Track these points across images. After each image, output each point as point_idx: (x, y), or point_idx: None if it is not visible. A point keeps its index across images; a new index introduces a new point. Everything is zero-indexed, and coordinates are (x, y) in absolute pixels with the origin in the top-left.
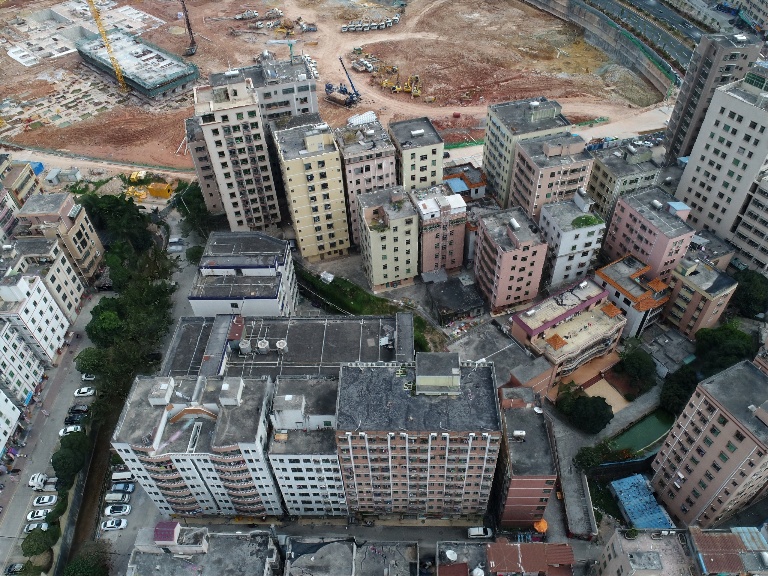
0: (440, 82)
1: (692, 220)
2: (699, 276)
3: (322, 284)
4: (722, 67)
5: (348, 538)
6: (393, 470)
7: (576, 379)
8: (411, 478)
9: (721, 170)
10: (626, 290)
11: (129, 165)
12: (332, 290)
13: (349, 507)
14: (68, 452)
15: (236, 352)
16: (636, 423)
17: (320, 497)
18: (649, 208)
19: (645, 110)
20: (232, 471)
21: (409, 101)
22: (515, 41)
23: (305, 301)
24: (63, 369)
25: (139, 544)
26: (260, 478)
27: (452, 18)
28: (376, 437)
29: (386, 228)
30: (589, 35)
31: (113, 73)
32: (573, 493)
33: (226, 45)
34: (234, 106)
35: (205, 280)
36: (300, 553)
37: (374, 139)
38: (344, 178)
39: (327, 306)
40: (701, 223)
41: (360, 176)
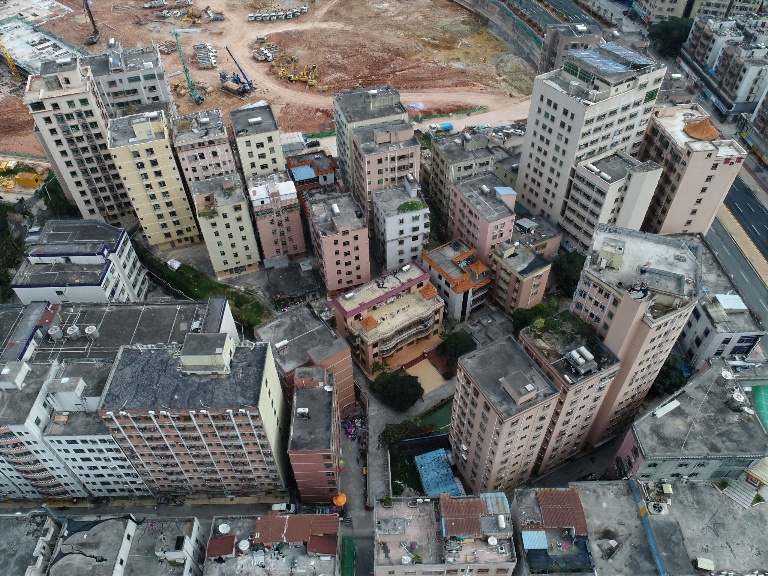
0: (337, 72)
1: (532, 205)
2: (517, 258)
3: (169, 271)
4: (565, 56)
5: (124, 515)
6: (173, 449)
7: (400, 359)
8: (194, 456)
9: (547, 156)
10: (446, 272)
11: (2, 155)
12: (178, 277)
13: (149, 487)
14: None
15: (47, 338)
16: (449, 400)
17: (116, 478)
18: (478, 193)
19: (525, 99)
20: (14, 454)
21: (303, 90)
22: (419, 31)
23: (157, 289)
24: None
25: None
26: (47, 460)
27: (361, 8)
28: (139, 416)
29: (214, 215)
30: (492, 25)
31: (6, 62)
32: (378, 468)
33: (130, 34)
34: (65, 94)
35: (33, 268)
36: (74, 531)
37: (208, 127)
38: (179, 166)
39: (176, 293)
40: (539, 208)
41: (195, 164)
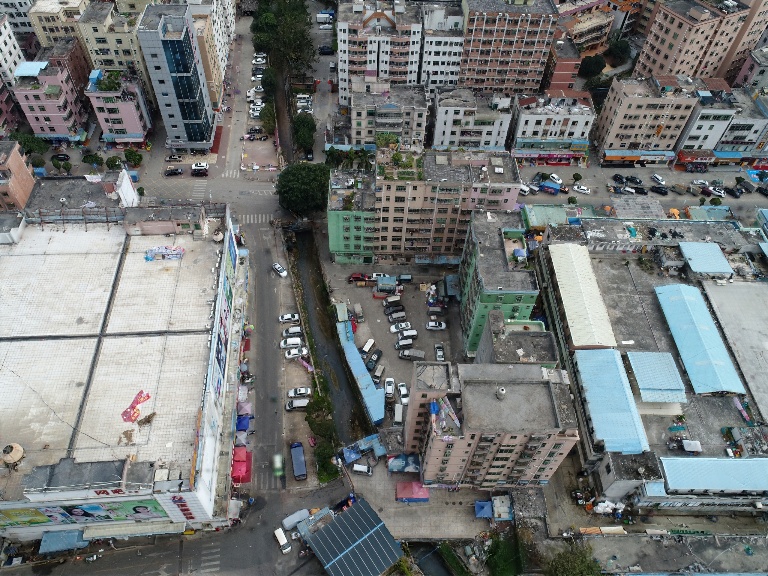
0: None
1: None
2: None
3: None
4: None
5: (468, 87)
6: (492, 54)
7: None
8: (500, 63)
9: None
10: None
11: None
12: None
13: None
14: (272, 74)
15: None
16: None
17: (442, 85)
18: None
19: None
20: (400, 52)
21: None
22: None
23: None
24: (238, 52)
25: (354, 82)
26: (413, 62)
27: None
28: (491, 18)
29: None
30: None
31: None
32: None
33: None
34: None
35: None
36: (443, 91)
37: None
38: None
39: None
40: None
41: None
